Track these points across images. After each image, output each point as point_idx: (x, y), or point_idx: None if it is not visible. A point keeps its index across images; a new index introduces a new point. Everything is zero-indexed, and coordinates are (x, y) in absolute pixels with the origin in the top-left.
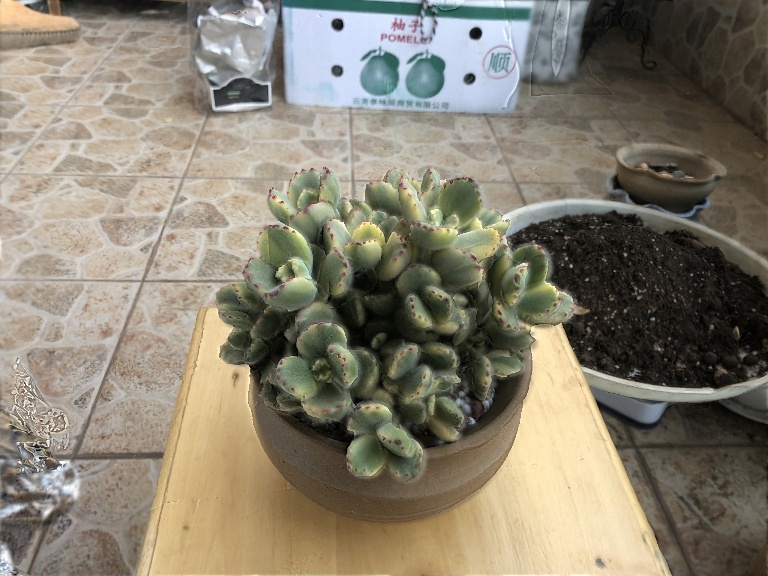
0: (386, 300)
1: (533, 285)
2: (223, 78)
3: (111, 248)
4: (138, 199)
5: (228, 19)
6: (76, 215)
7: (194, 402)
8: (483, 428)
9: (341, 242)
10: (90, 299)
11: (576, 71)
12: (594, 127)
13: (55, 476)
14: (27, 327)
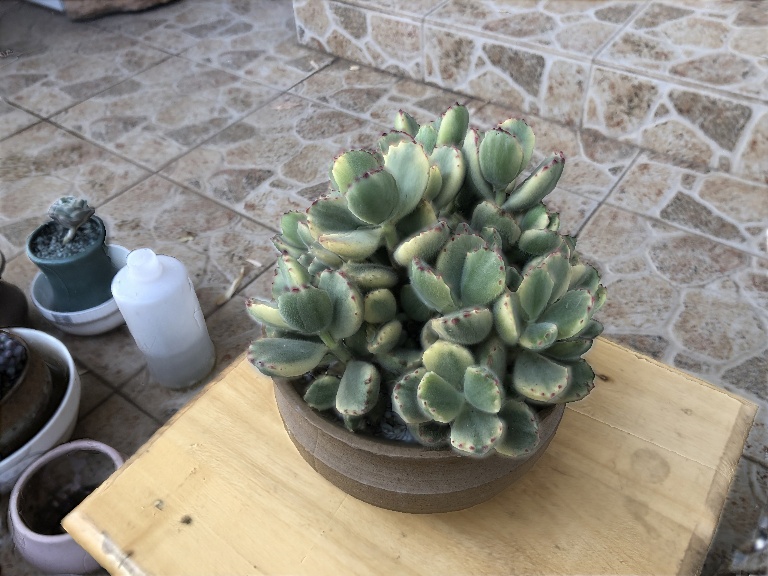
0: None
1: None
2: None
3: None
4: None
5: None
6: None
7: None
8: None
9: (436, 163)
10: None
11: None
12: None
13: (759, 454)
14: None
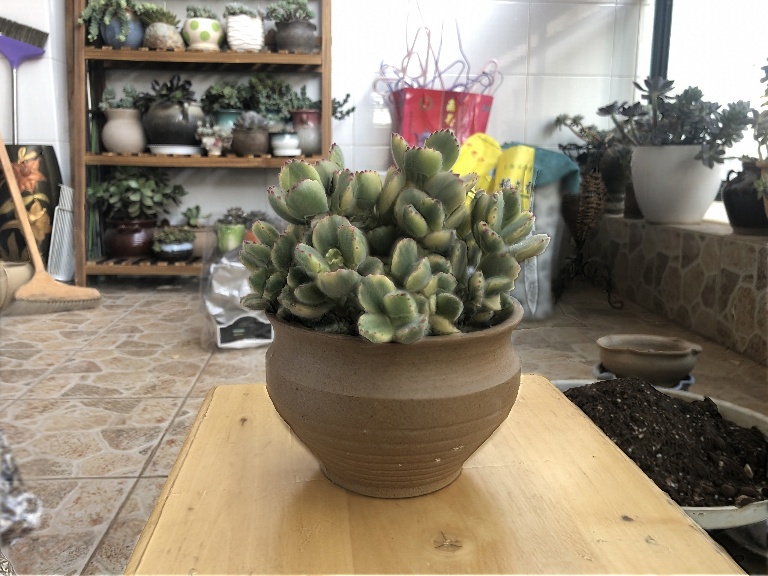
0: (387, 230)
1: (511, 219)
2: (229, 318)
3: (110, 452)
4: (141, 414)
5: (237, 266)
6: (78, 427)
7: (202, 436)
8: (483, 330)
9: None
10: (83, 493)
11: (551, 310)
12: (575, 348)
13: None
14: (13, 519)
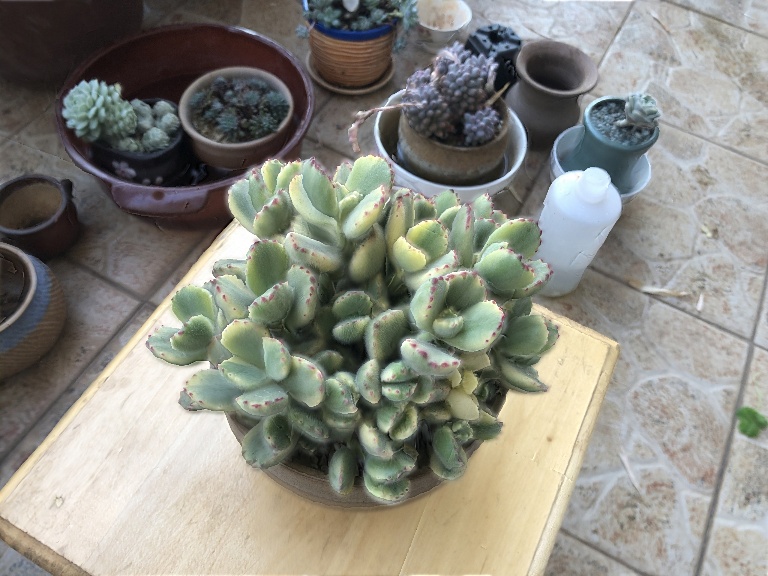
0: None
1: None
2: None
3: None
4: None
5: None
6: None
7: None
8: None
9: None
10: None
11: None
12: None
13: None
14: None
